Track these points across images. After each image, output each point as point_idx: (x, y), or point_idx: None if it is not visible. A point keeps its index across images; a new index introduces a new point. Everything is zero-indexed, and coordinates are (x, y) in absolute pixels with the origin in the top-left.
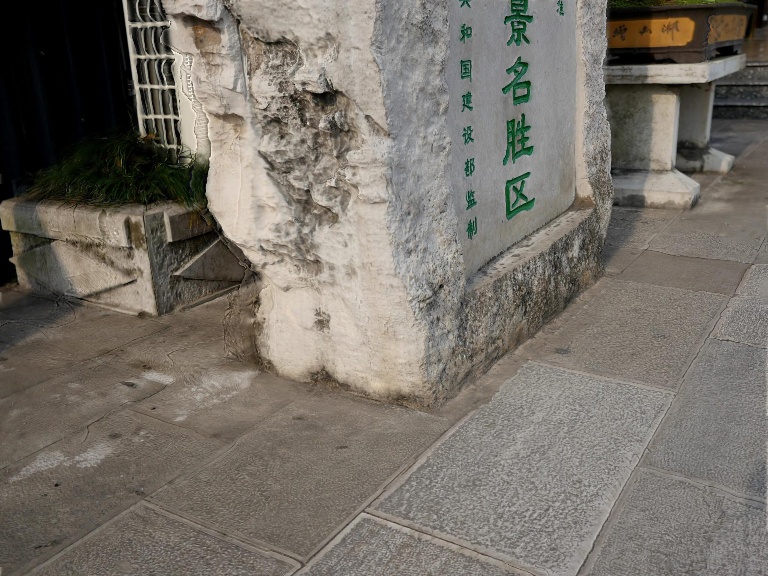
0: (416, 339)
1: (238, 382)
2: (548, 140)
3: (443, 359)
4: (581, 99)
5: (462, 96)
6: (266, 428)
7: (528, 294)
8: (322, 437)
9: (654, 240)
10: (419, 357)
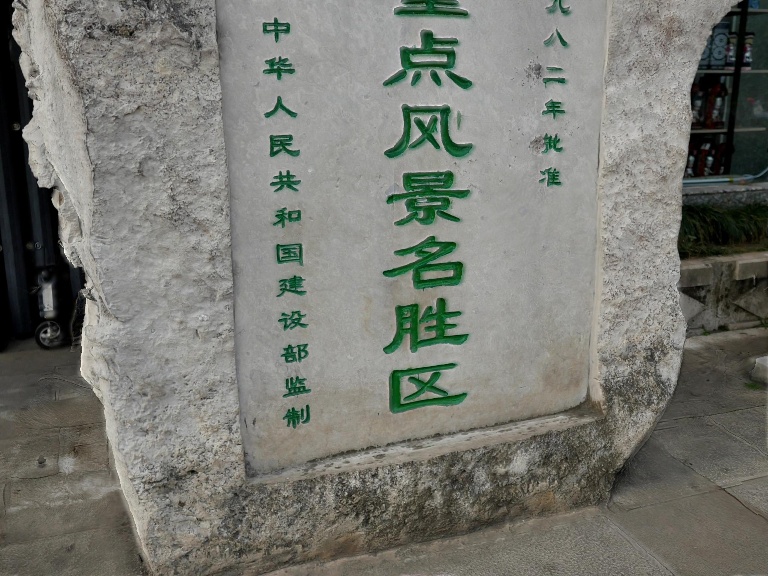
0: (142, 517)
1: (80, 492)
2: (511, 329)
3: (184, 545)
4: (600, 283)
5: (280, 280)
6: (45, 545)
7: (373, 504)
8: (53, 574)
9: (766, 478)
10: (144, 535)
